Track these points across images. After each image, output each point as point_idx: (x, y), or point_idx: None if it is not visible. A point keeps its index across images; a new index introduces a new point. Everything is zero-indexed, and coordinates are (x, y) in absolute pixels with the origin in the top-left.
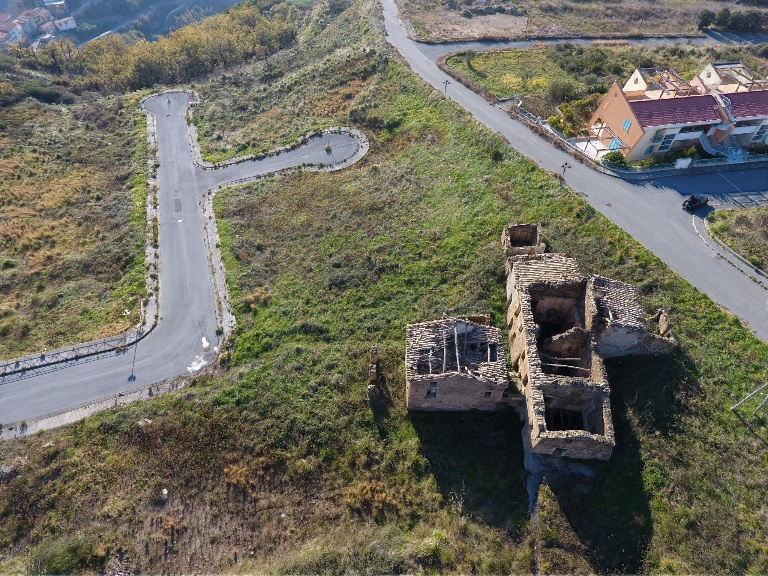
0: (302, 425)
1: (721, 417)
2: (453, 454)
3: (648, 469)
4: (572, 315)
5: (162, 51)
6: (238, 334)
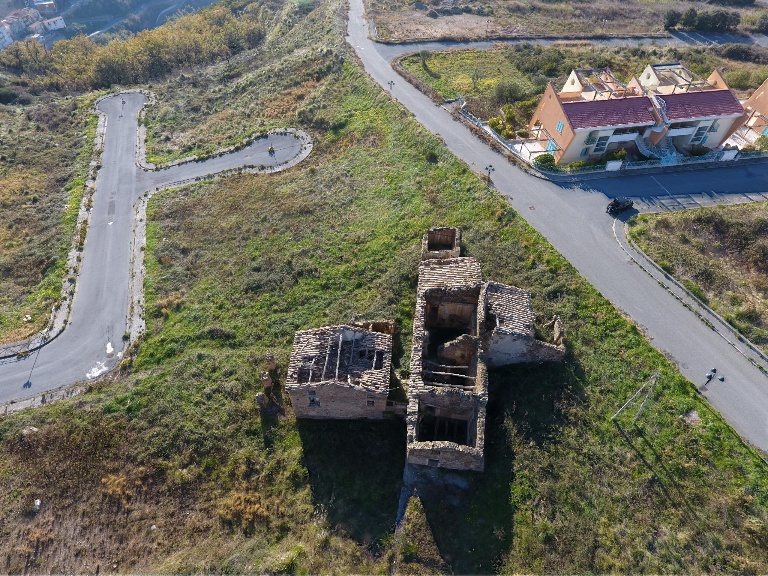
0: (188, 434)
1: (600, 427)
2: (333, 464)
3: (517, 481)
4: (471, 321)
5: (125, 51)
6: (144, 339)
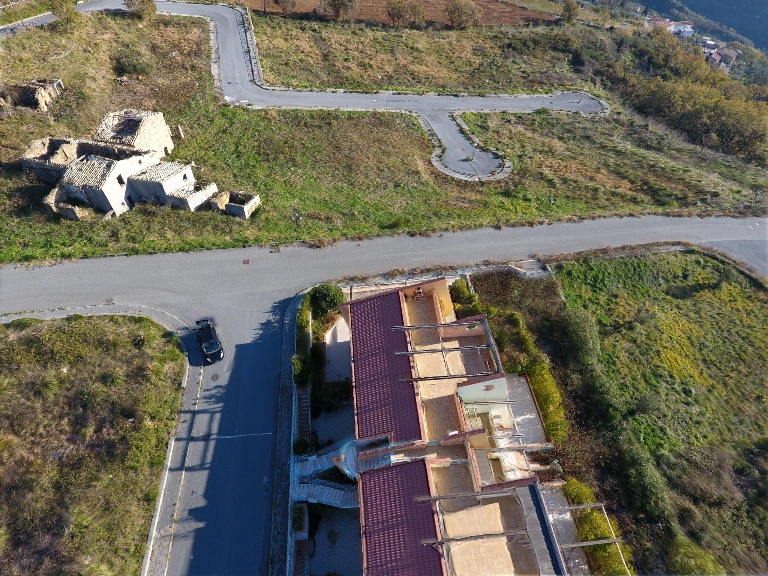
0: None
1: None
2: None
3: (1, 179)
4: None
5: (695, 96)
6: (244, 109)
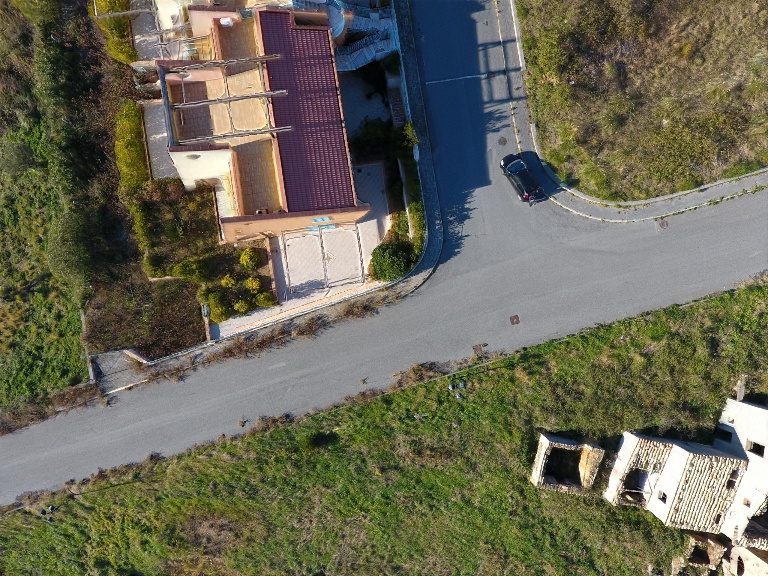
0: None
1: None
2: None
3: None
4: None
5: None
6: None
